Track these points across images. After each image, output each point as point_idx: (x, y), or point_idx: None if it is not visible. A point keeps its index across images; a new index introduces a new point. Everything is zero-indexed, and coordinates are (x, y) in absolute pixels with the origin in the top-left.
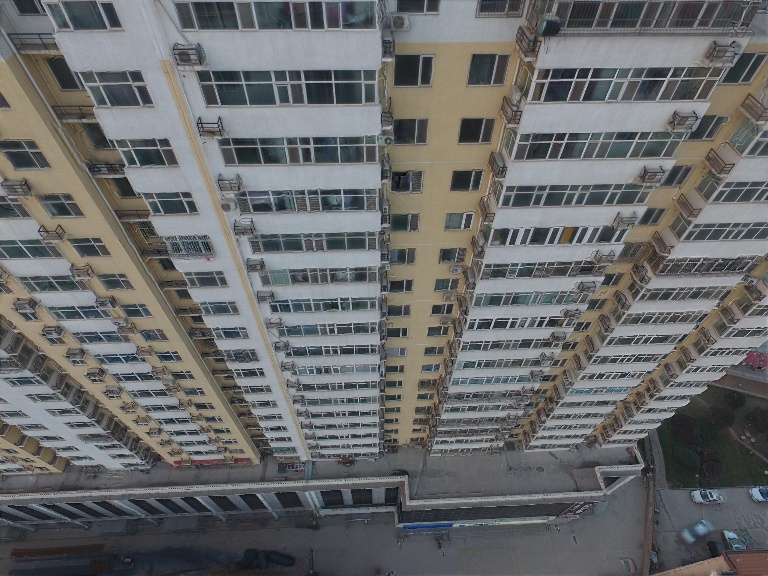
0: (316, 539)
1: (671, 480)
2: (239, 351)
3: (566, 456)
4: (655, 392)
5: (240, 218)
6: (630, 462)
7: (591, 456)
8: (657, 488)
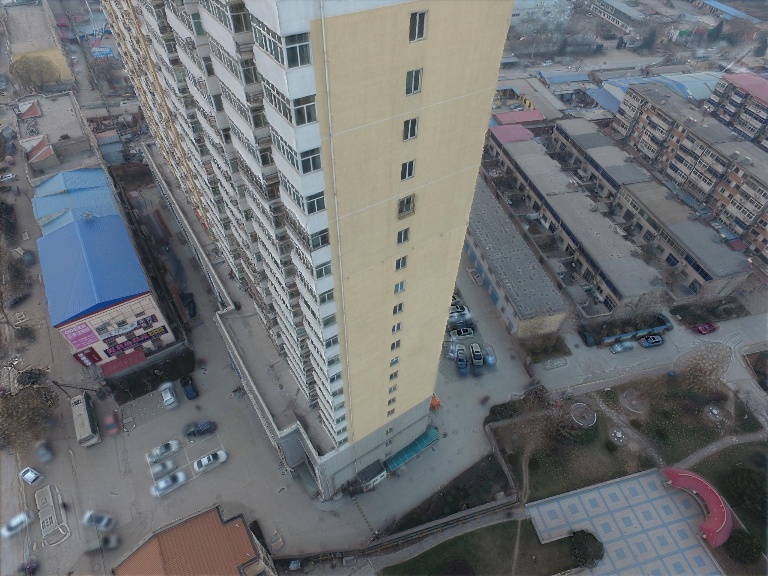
0: (211, 322)
1: (386, 573)
2: (170, 110)
3: (302, 401)
4: (309, 356)
5: (138, 4)
6: (321, 452)
7: (312, 420)
8: (370, 559)
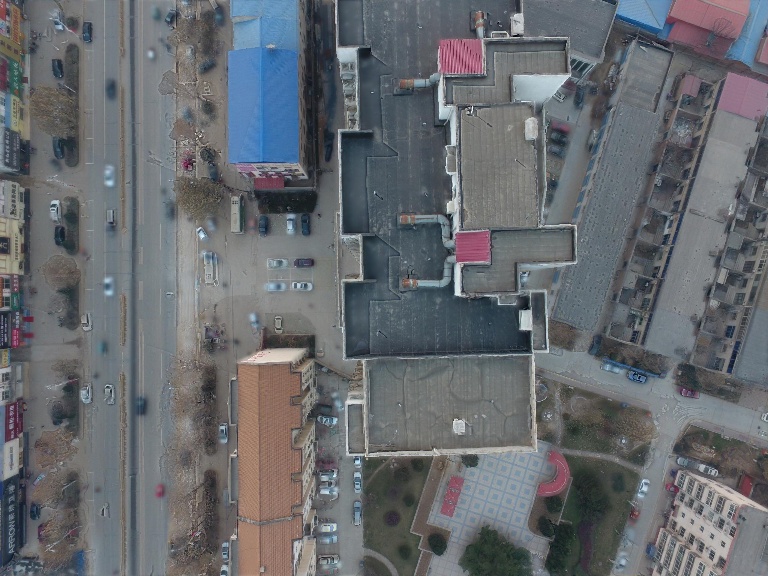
0: None
1: None
2: None
3: None
4: None
5: None
6: None
7: None
8: None
